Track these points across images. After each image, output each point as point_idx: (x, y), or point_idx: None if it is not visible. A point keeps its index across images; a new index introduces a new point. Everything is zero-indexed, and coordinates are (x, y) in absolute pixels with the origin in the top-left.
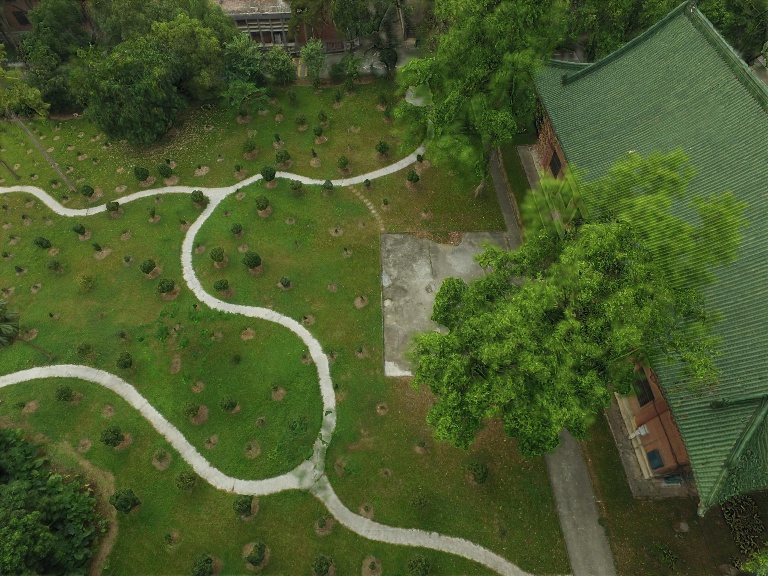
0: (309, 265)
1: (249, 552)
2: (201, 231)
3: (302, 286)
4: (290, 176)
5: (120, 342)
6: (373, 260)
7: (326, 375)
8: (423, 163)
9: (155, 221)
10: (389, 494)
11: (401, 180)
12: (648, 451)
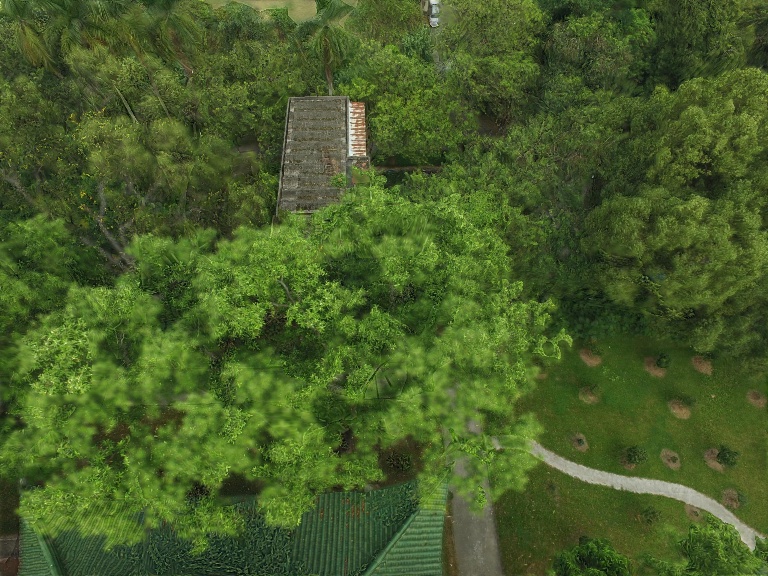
0: None
1: None
2: None
3: None
4: None
5: None
6: None
7: None
8: None
9: None
10: (675, 530)
11: None
12: None
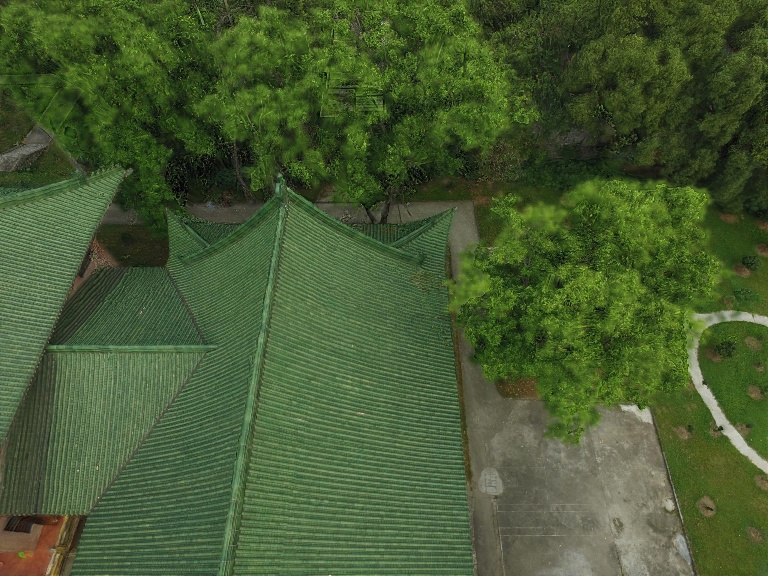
0: None
1: (717, 278)
2: None
3: None
4: None
5: None
6: None
7: (714, 410)
8: None
9: None
10: None
11: None
12: None
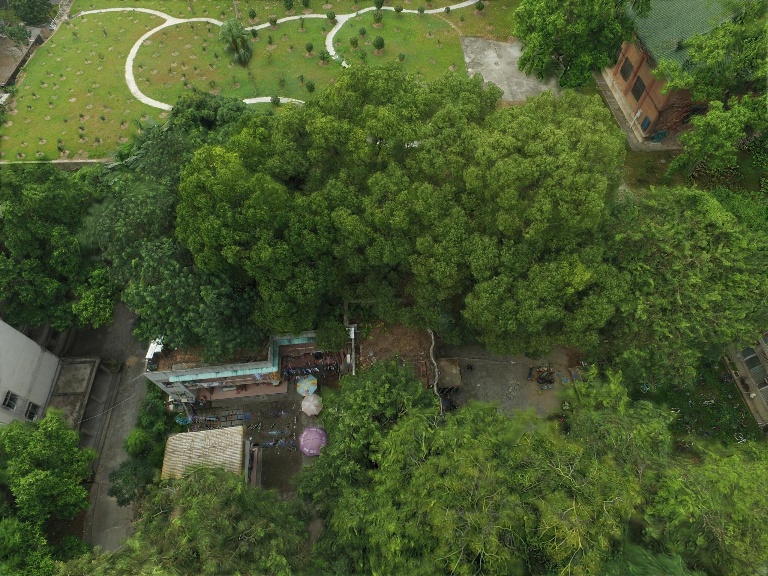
0: (415, 51)
1: None
2: (337, 35)
3: (412, 61)
4: (391, 8)
5: (299, 85)
6: (457, 49)
7: None
8: (484, 2)
9: (303, 31)
10: None
11: (470, 11)
12: (642, 122)
